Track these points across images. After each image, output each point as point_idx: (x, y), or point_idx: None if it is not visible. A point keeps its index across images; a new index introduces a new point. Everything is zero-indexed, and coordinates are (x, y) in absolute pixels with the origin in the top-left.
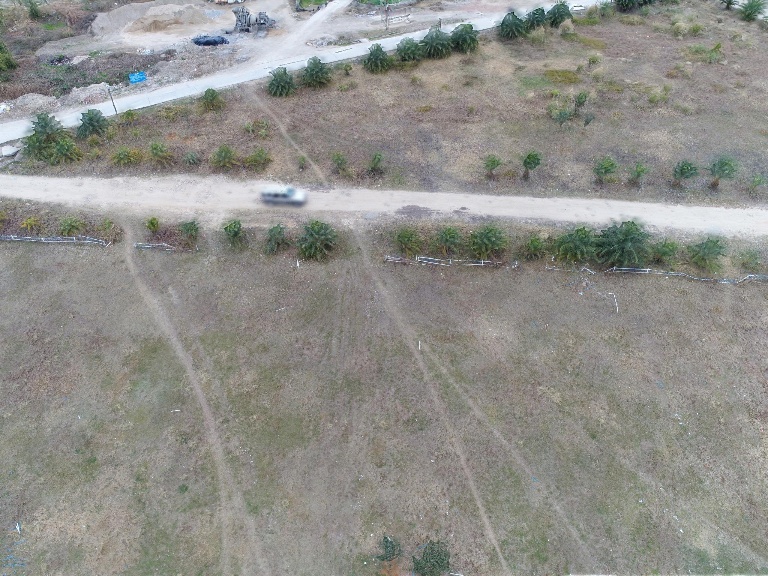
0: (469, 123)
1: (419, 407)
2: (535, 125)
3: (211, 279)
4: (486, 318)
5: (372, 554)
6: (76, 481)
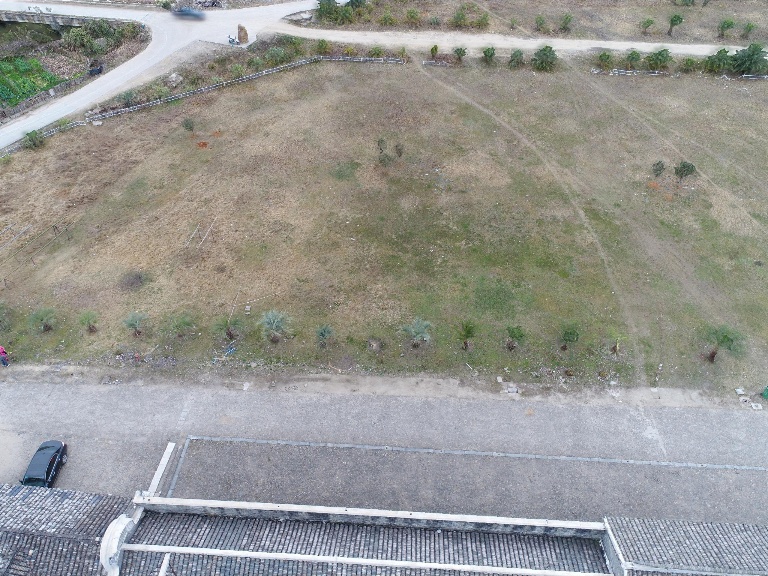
0: (617, 7)
1: (642, 132)
2: (665, 8)
3: (482, 80)
4: (668, 97)
5: (641, 181)
6: (457, 155)
